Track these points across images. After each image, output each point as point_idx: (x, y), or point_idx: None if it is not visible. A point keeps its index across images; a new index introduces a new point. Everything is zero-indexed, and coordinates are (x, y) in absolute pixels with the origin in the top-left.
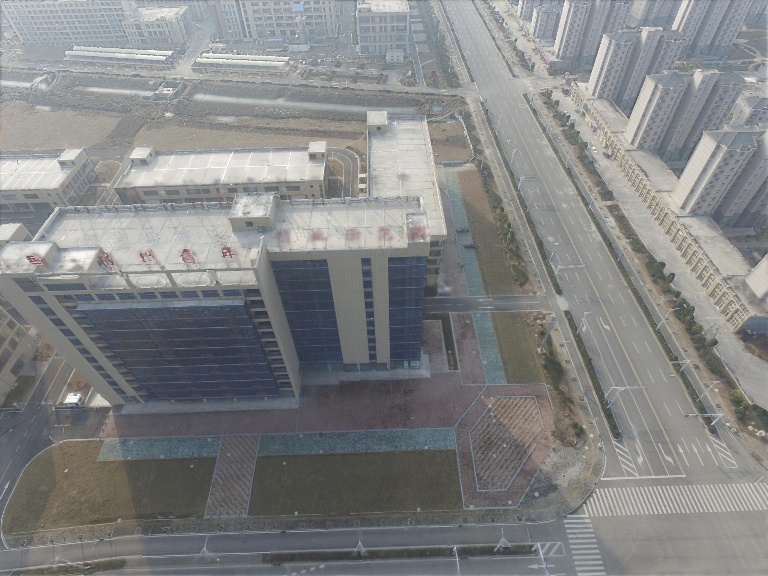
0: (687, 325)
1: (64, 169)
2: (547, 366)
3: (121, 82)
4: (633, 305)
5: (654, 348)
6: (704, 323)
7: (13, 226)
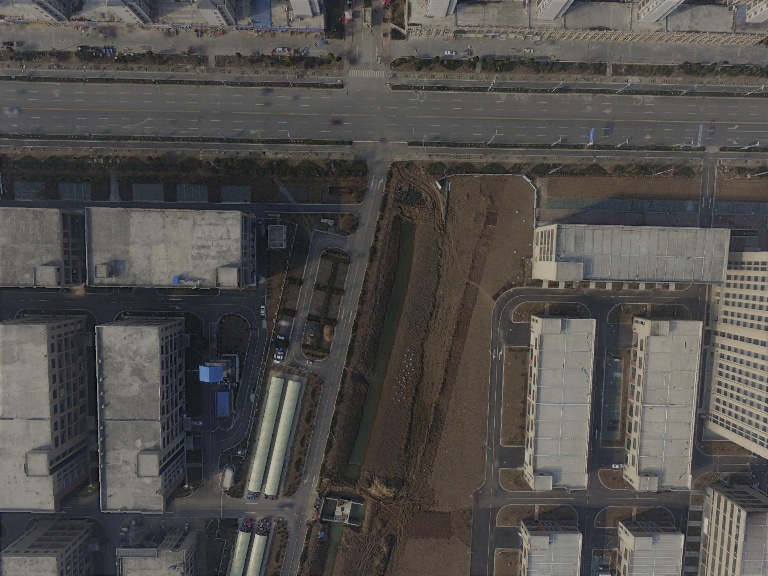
0: (748, 74)
1: (550, 542)
2: (762, 176)
3: (314, 571)
4: (720, 101)
5: (756, 103)
6: (743, 60)
7: (637, 542)
